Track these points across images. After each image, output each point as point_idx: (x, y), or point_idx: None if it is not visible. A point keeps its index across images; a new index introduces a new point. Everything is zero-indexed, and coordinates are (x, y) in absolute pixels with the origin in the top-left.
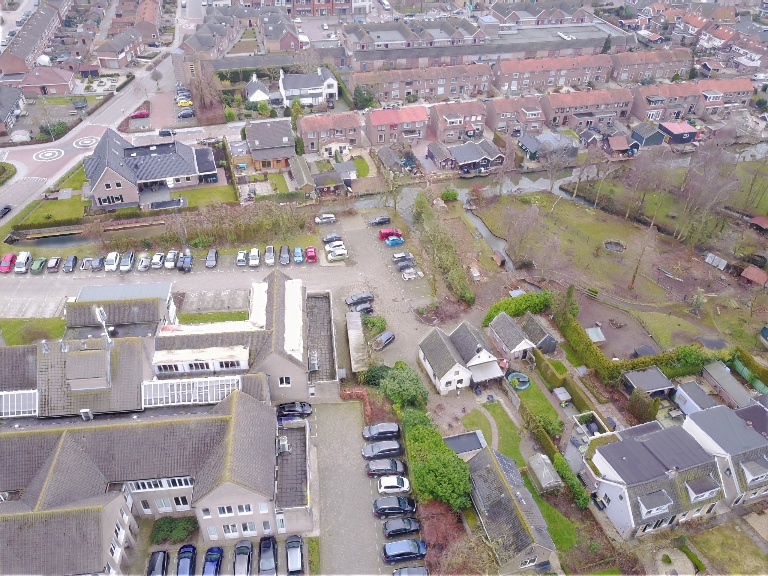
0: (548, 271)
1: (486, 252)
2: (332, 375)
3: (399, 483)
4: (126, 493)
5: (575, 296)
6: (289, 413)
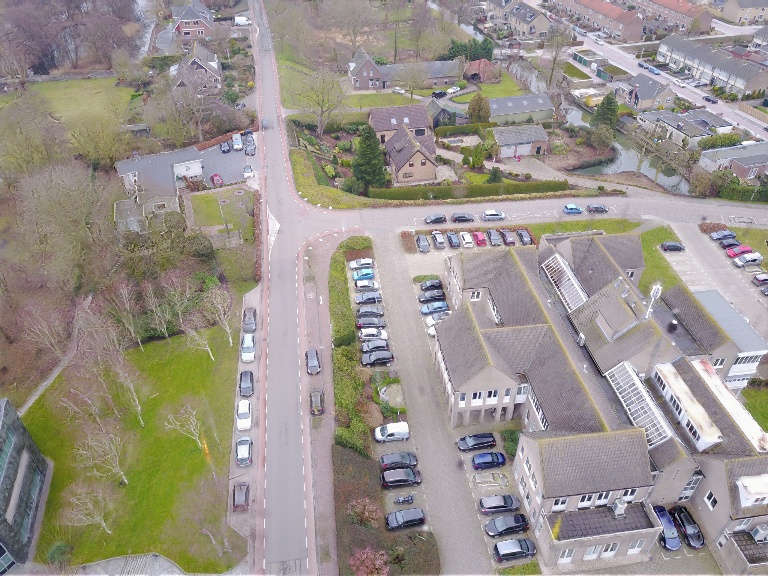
0: None
1: None
2: (759, 561)
3: None
4: (525, 391)
5: None
6: (679, 520)
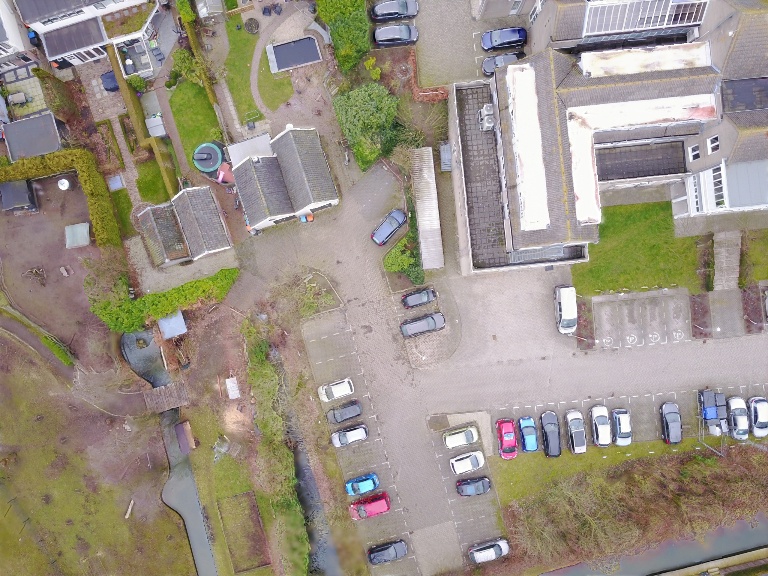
0: (109, 408)
1: (204, 462)
2: (461, 105)
3: None
4: None
5: (81, 343)
6: (511, 53)
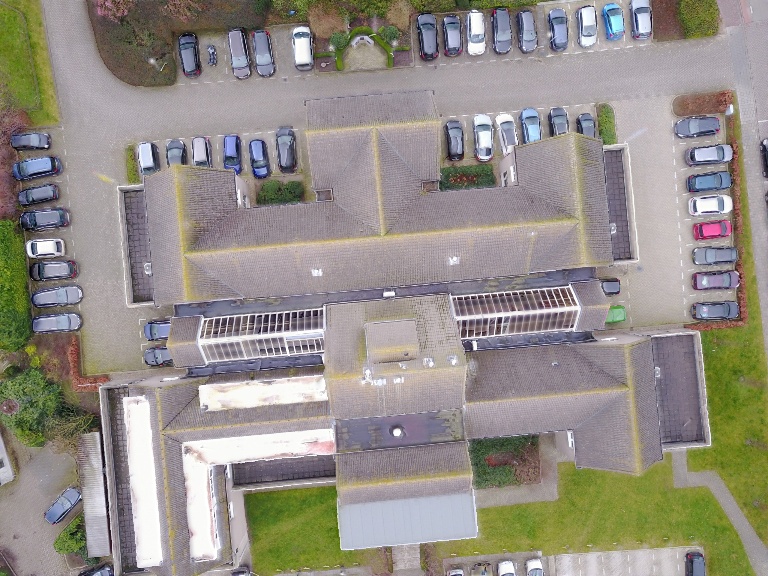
0: None
1: None
2: (112, 404)
3: (36, 247)
4: None
5: None
6: None
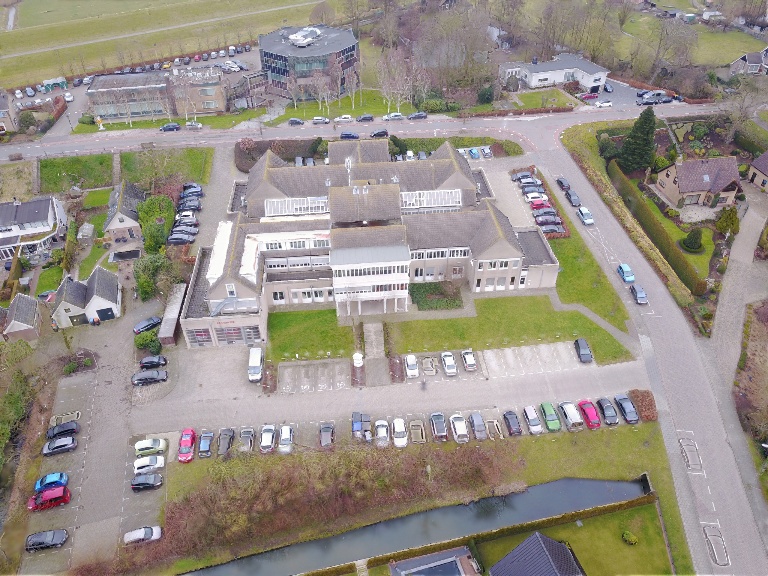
0: None
1: None
2: (204, 257)
3: None
4: None
5: None
6: None
